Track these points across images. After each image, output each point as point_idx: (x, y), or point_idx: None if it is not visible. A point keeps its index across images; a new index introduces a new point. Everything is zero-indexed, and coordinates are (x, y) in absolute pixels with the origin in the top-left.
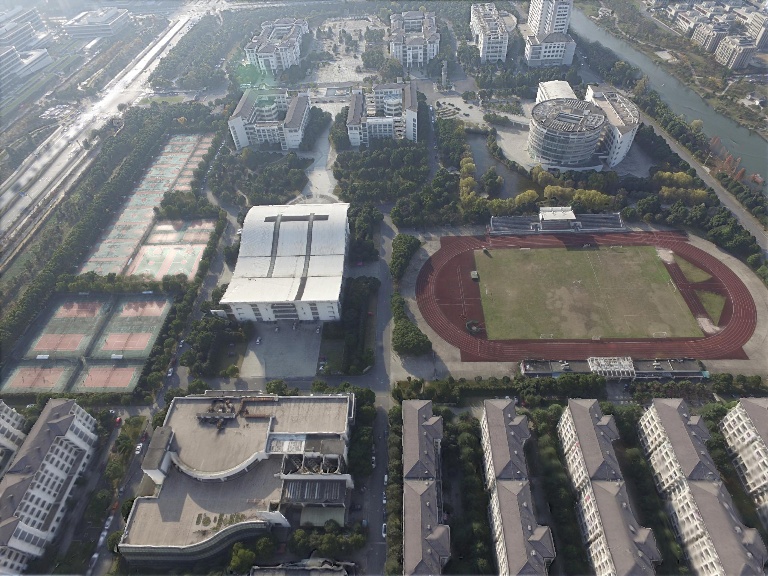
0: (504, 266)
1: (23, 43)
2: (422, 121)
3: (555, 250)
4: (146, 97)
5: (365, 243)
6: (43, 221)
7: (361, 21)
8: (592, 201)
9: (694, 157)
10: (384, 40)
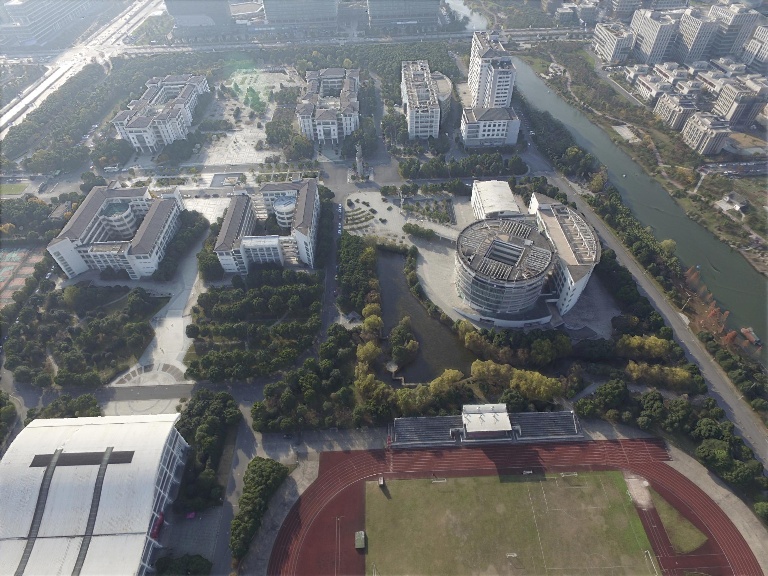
0: (406, 517)
1: None
2: (322, 236)
3: (482, 481)
4: None
5: (200, 480)
6: None
7: (276, 74)
8: (535, 393)
9: (668, 297)
10: (298, 102)
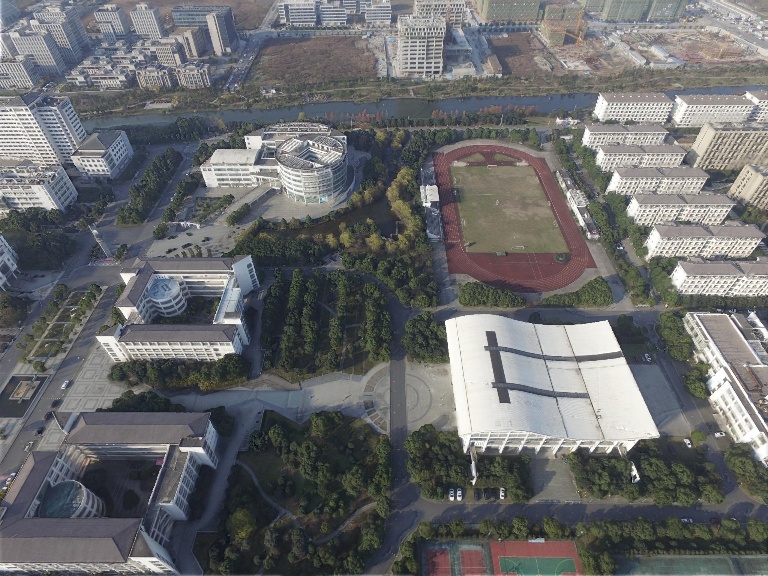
0: (485, 236)
1: None
2: None
3: (461, 208)
4: None
5: None
6: None
7: None
8: None
9: (341, 130)
10: None
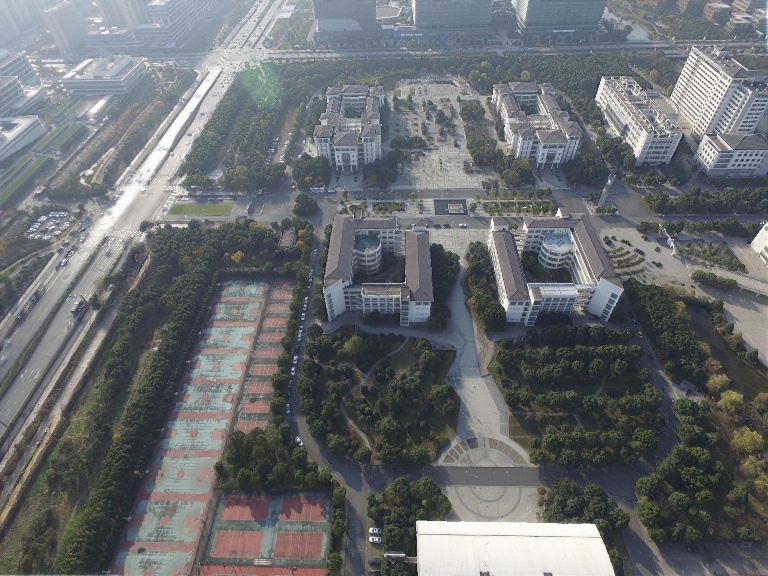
0: None
1: (7, 104)
2: None
3: None
4: (178, 203)
5: None
6: (24, 487)
7: (445, 85)
8: None
9: None
10: (486, 118)
